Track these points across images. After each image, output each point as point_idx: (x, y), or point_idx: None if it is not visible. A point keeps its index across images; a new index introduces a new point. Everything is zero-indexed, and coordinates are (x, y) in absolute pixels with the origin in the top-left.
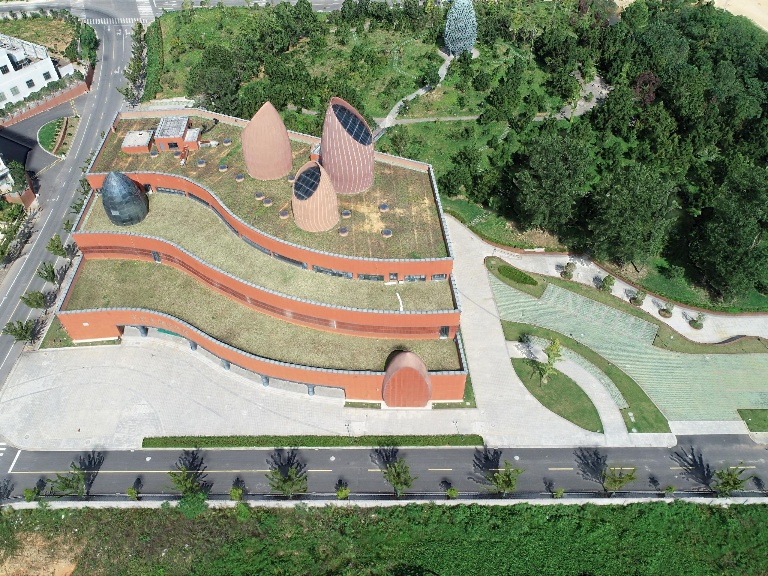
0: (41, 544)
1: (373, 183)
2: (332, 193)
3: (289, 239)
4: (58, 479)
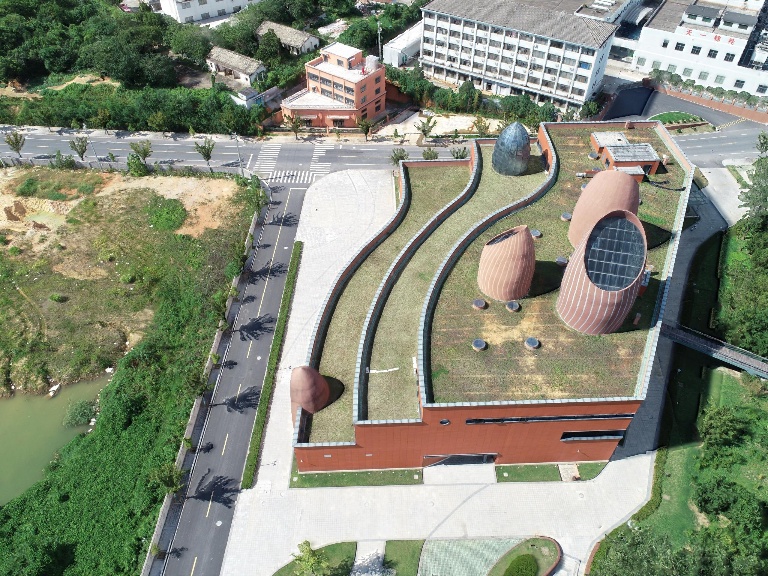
0: (235, 212)
1: (588, 334)
2: (504, 266)
3: (464, 262)
4: (259, 196)
